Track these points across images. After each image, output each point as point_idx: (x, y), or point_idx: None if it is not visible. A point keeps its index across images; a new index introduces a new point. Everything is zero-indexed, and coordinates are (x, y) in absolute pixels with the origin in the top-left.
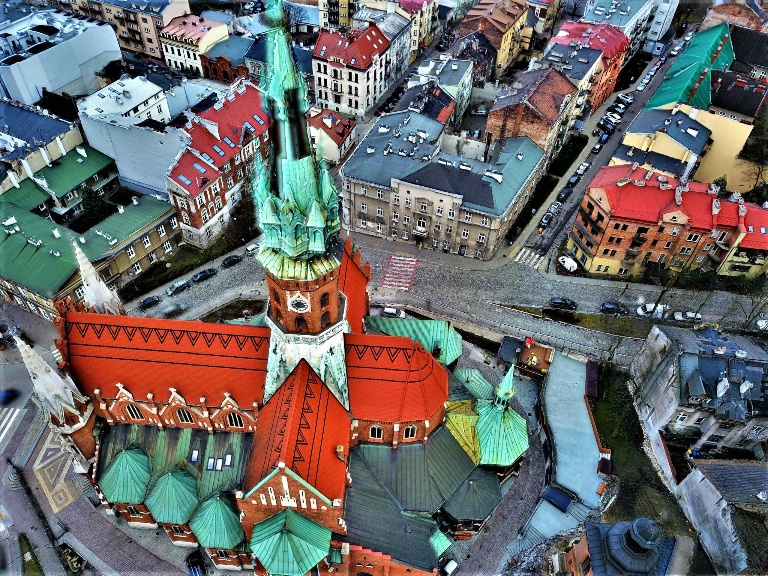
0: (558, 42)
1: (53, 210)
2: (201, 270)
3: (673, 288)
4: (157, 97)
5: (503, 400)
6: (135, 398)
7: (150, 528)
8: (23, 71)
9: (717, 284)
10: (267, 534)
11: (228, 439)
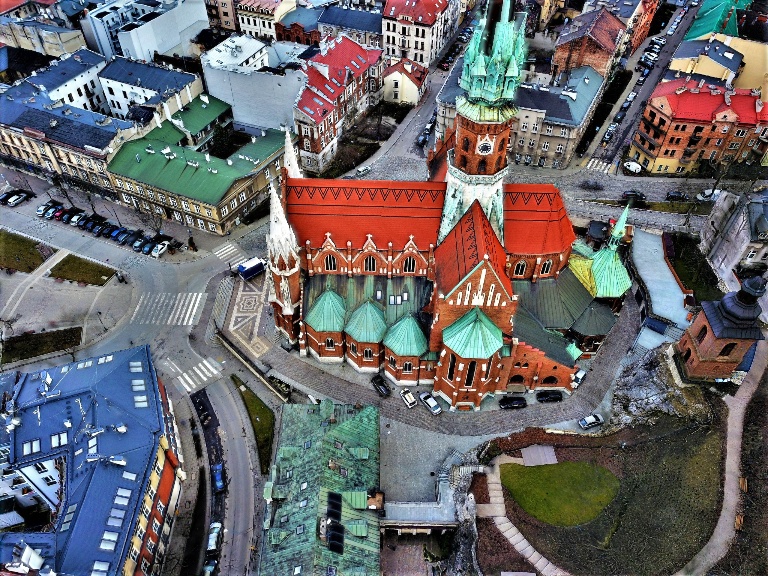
0: None
1: None
2: None
3: (723, 180)
4: (261, 52)
5: (616, 240)
6: (337, 246)
7: (337, 362)
8: (140, 36)
9: (760, 175)
10: (459, 329)
11: (403, 282)
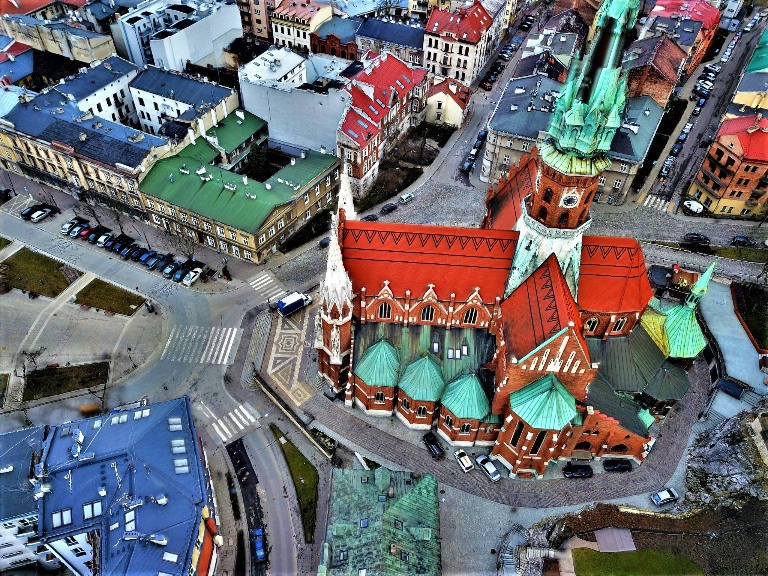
0: (660, 15)
1: (220, 166)
2: (363, 216)
3: None
4: (300, 66)
5: (697, 298)
6: (395, 295)
7: (385, 416)
8: (173, 44)
9: None
10: (531, 396)
11: (463, 334)
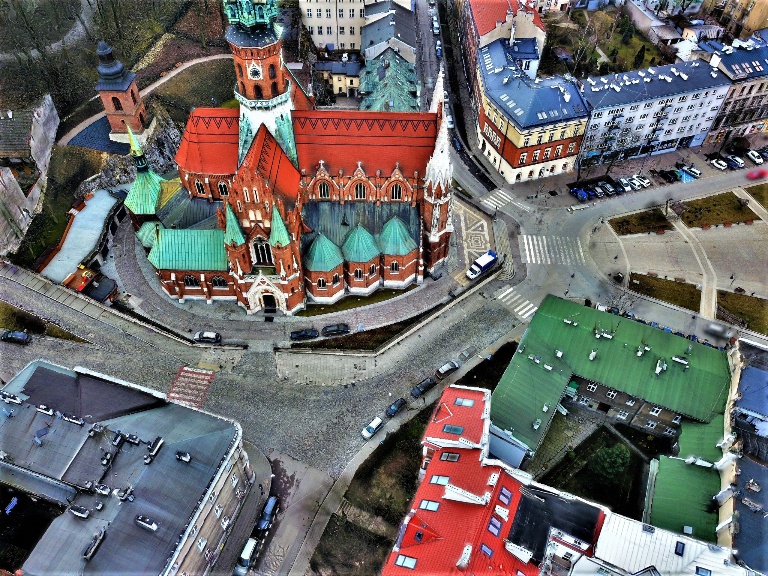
0: None
1: None
2: (431, 396)
3: None
4: None
5: None
6: None
7: None
8: None
9: None
10: None
11: None
